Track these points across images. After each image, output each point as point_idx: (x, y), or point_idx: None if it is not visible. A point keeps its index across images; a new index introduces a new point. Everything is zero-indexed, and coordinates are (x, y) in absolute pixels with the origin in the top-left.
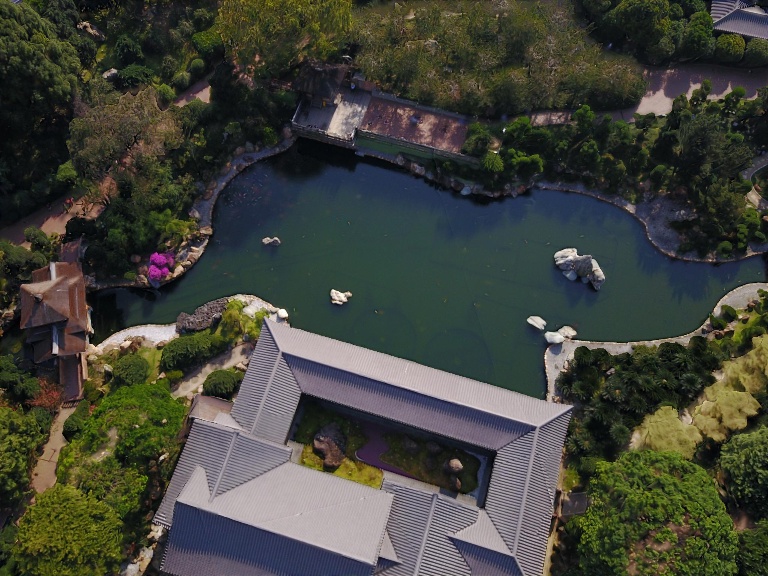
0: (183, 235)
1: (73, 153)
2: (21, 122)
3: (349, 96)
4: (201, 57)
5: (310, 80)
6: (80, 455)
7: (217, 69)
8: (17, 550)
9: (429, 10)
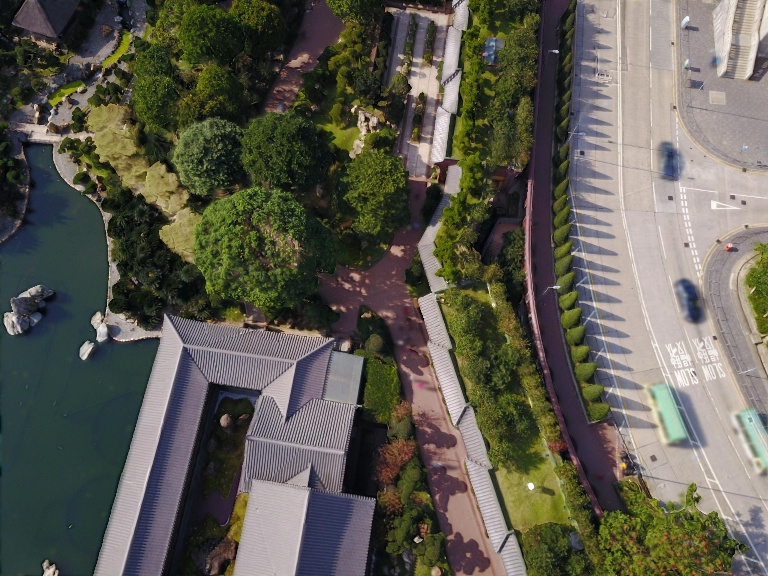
0: None
1: None
2: None
3: None
4: None
5: None
6: None
7: None
8: None
9: None
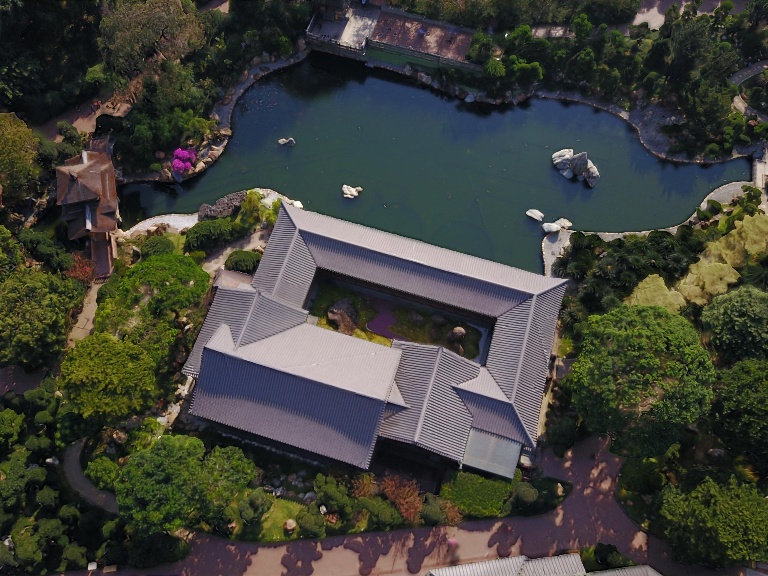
0: (204, 135)
1: (104, 49)
2: (54, 22)
3: (360, 11)
4: None
5: None
6: (115, 308)
7: None
8: (61, 383)
9: None
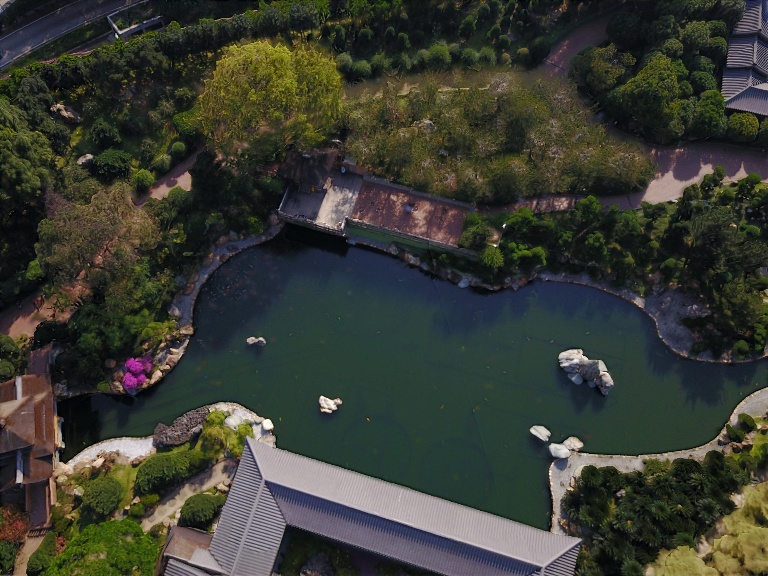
0: (162, 335)
1: (41, 258)
2: None
3: (339, 180)
4: (182, 140)
5: (297, 167)
6: None
7: (198, 158)
8: None
9: (424, 91)
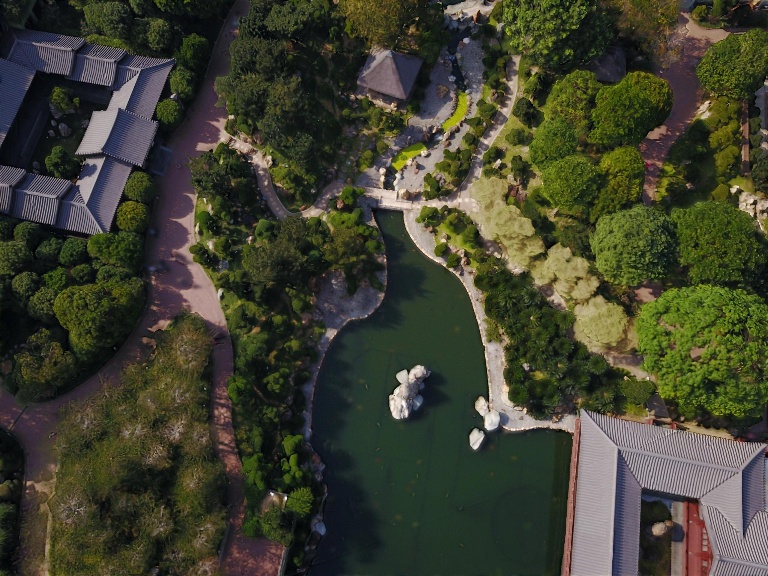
0: None
1: None
2: None
3: None
4: None
5: None
6: None
7: None
8: None
9: None
